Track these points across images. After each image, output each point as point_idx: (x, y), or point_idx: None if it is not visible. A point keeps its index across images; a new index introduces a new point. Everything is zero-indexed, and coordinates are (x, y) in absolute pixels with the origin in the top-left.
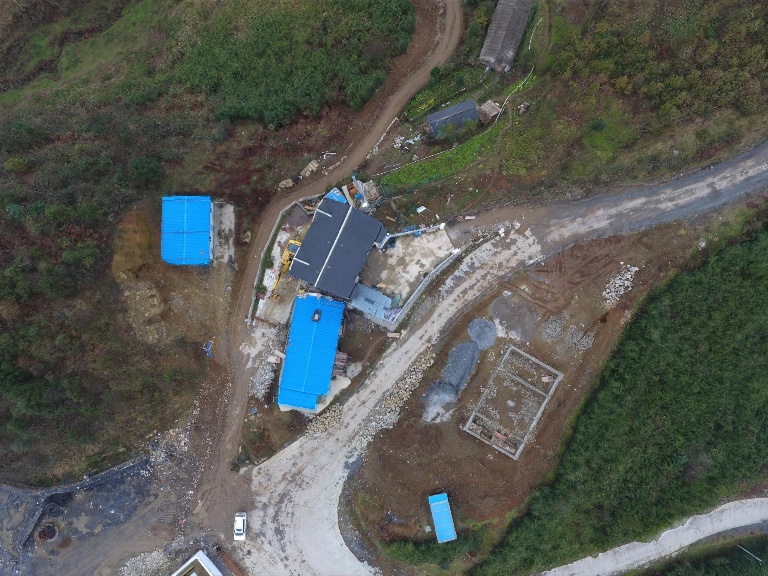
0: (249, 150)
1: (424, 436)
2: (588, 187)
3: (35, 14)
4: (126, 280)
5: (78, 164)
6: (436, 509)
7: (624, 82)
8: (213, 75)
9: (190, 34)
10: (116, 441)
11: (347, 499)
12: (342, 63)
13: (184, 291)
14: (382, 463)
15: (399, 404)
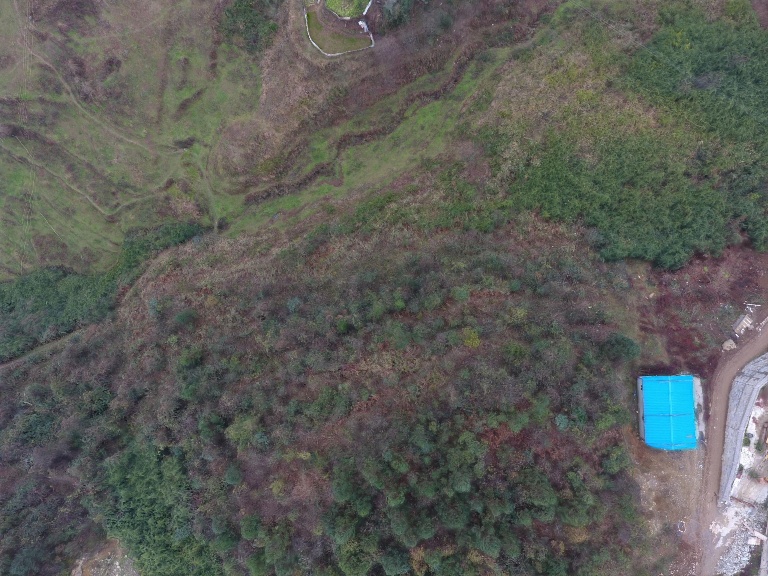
0: (664, 301)
1: None
2: None
3: (321, 119)
4: (634, 475)
5: (566, 349)
6: None
7: None
8: (576, 205)
9: (520, 151)
10: None
11: None
12: (745, 203)
13: (660, 472)
14: None
15: None
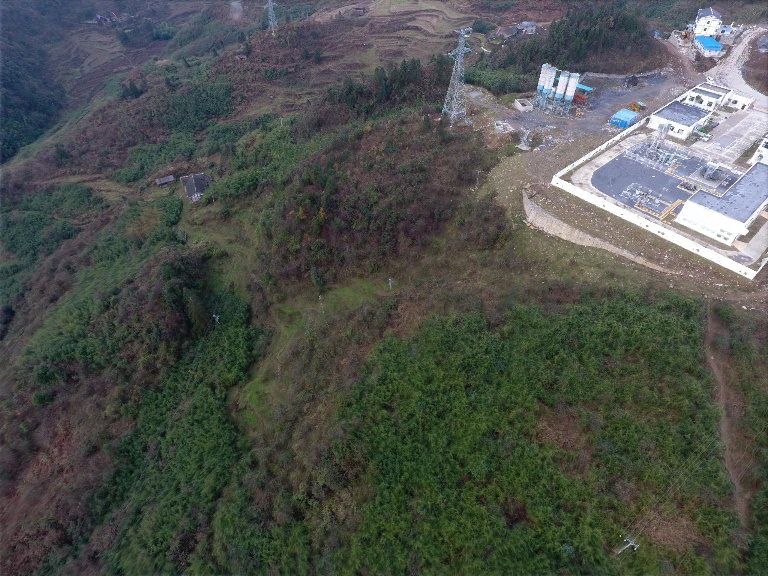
0: None
1: (765, 52)
2: None
3: None
4: None
5: None
6: None
7: None
8: None
9: None
10: None
11: (745, 79)
12: None
13: None
14: (752, 67)
15: (747, 55)
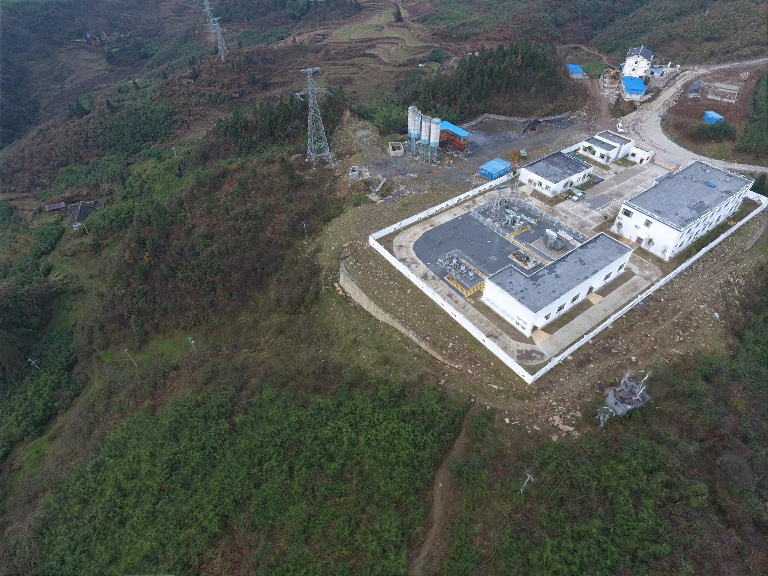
0: None
1: None
2: (717, 61)
3: None
4: None
5: None
6: (709, 112)
7: (715, 49)
8: None
9: None
10: (558, 108)
11: (664, 127)
12: None
13: None
14: (675, 114)
15: (674, 100)
